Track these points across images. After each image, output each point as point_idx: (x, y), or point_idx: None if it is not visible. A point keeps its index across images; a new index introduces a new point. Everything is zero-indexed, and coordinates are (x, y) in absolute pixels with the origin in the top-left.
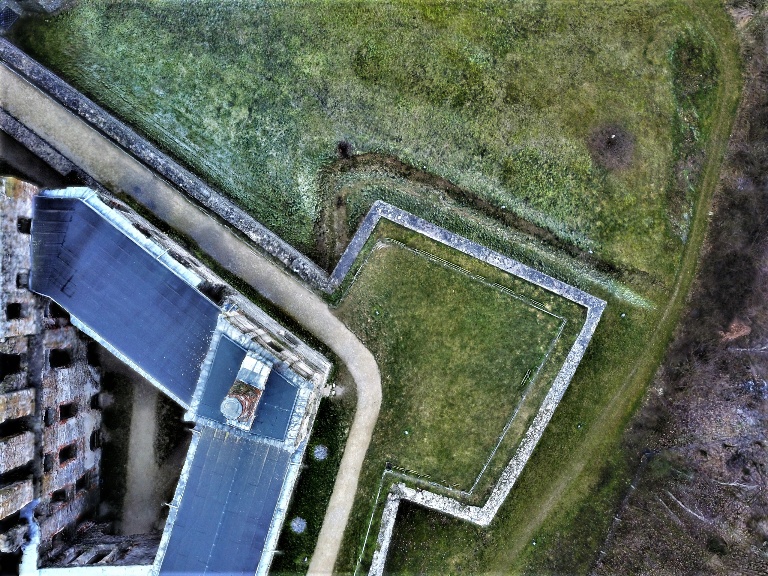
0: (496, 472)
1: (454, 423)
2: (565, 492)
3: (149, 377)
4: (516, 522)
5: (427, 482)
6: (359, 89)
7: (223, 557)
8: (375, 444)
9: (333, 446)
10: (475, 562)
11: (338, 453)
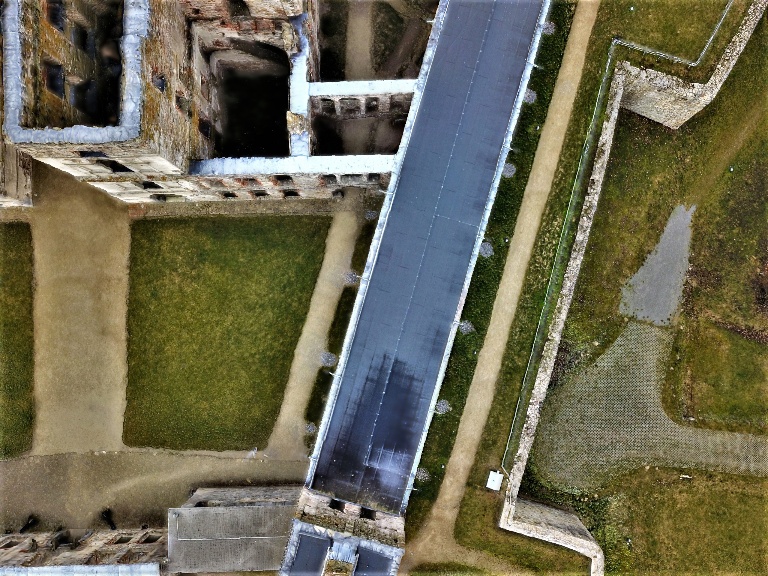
0: (719, 49)
1: (678, 0)
2: (760, 122)
3: None
4: (713, 149)
5: (652, 59)
6: None
7: (490, 63)
8: (601, 21)
9: (560, 22)
10: (675, 185)
11: (565, 29)
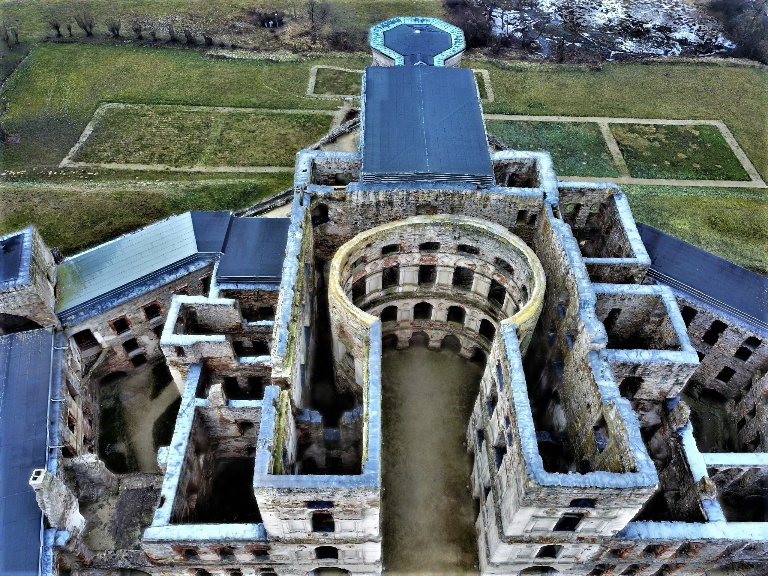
0: None
1: None
2: None
3: (731, 318)
4: None
5: None
6: (719, 236)
7: None
8: None
9: None
10: None
11: None
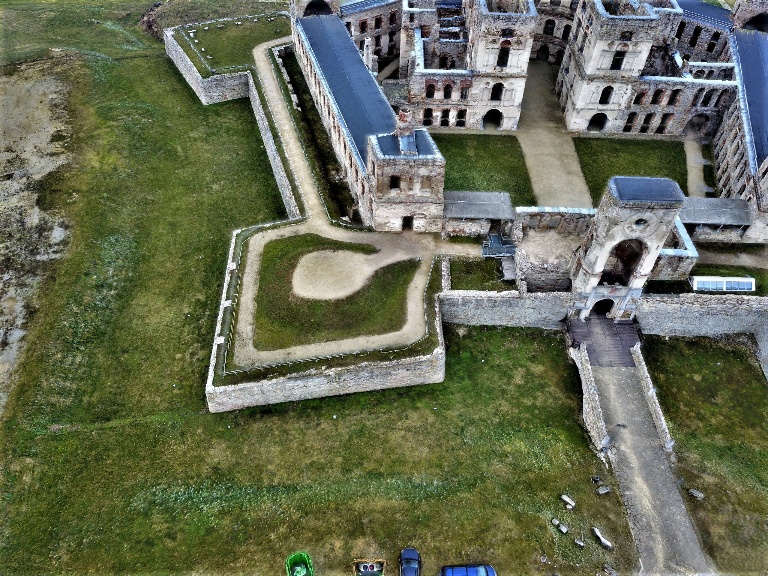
0: None
1: None
2: None
3: (704, 23)
4: None
5: None
6: None
7: None
8: None
9: None
10: None
11: None
